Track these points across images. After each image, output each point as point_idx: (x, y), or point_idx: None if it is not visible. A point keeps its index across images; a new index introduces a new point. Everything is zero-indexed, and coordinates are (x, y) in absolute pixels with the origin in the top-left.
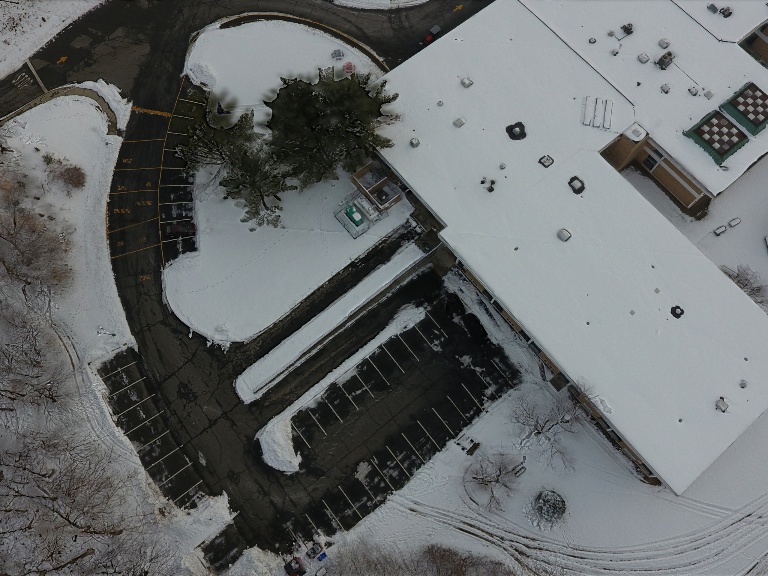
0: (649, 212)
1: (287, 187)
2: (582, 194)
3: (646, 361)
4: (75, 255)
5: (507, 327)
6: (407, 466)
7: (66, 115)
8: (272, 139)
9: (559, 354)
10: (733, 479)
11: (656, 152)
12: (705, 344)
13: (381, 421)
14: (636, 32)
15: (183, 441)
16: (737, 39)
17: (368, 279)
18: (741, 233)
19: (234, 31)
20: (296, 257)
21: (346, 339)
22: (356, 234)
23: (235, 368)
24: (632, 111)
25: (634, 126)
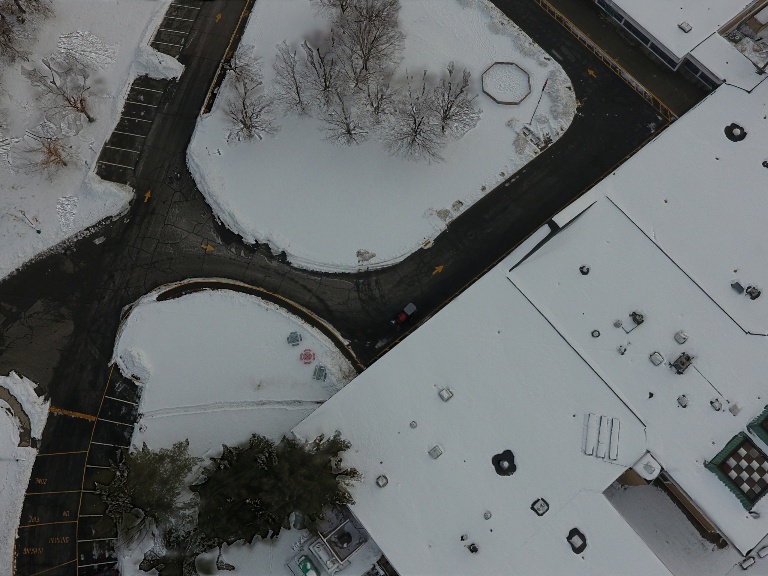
0: None
1: (223, 566)
2: (583, 554)
3: None
4: None
5: None
6: None
7: None
8: None
9: None
10: None
11: None
12: None
13: None
14: (647, 321)
15: None
16: (767, 330)
17: None
18: None
19: (173, 305)
20: None
21: None
22: None
23: None
24: (643, 434)
25: (646, 458)
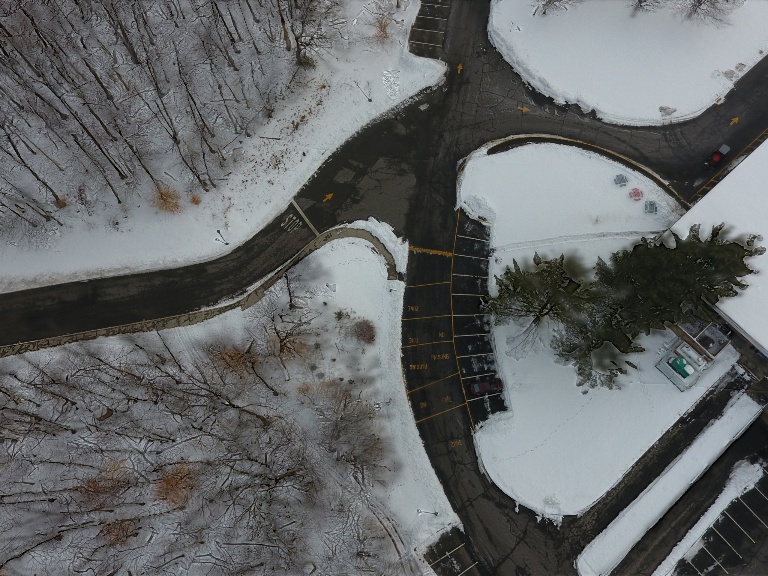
0: None
1: (632, 349)
2: None
3: None
4: (379, 421)
5: None
6: None
7: (345, 261)
8: (626, 302)
9: None
10: None
11: None
12: None
13: None
14: None
15: None
16: None
17: (703, 437)
18: None
19: (504, 157)
20: (618, 414)
21: (684, 505)
22: None
23: (573, 546)
24: None
25: None
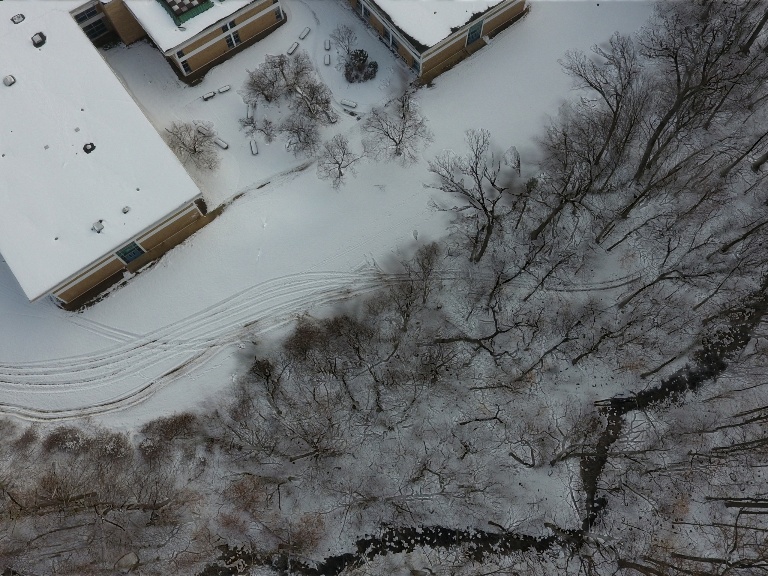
0: (96, 64)
1: None
2: (41, 47)
3: (44, 188)
4: None
5: None
6: None
7: None
8: None
9: None
10: (145, 308)
11: None
12: (105, 176)
13: None
14: None
15: None
16: None
17: None
18: (229, 99)
19: None
20: None
21: None
22: None
23: None
24: None
25: None
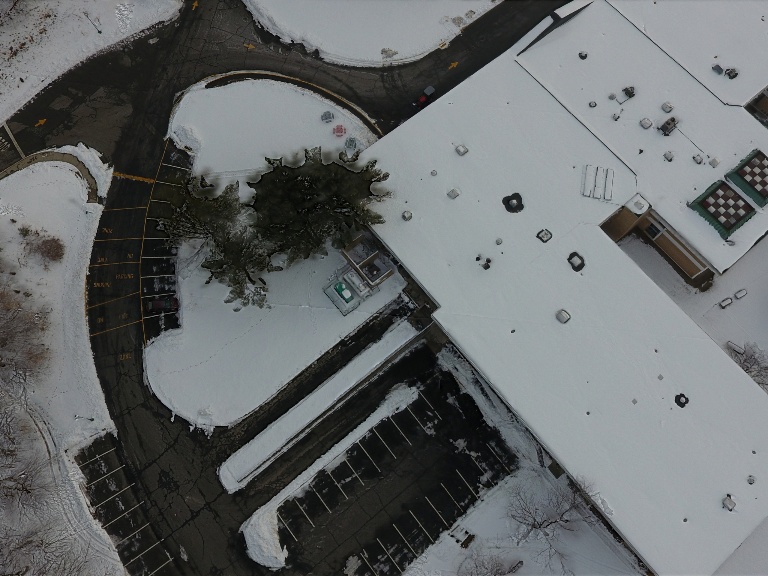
0: (652, 291)
1: (273, 268)
2: (582, 271)
3: (649, 455)
4: (52, 333)
5: (504, 408)
6: (399, 560)
7: (44, 183)
8: None
9: (558, 447)
10: (740, 574)
11: (659, 222)
12: (711, 436)
13: (371, 511)
14: (638, 95)
15: (164, 534)
16: (743, 102)
17: (358, 359)
18: (747, 305)
19: (220, 91)
20: (283, 335)
21: (335, 422)
22: (346, 312)
23: (219, 454)
24: (634, 181)
25: (636, 198)
